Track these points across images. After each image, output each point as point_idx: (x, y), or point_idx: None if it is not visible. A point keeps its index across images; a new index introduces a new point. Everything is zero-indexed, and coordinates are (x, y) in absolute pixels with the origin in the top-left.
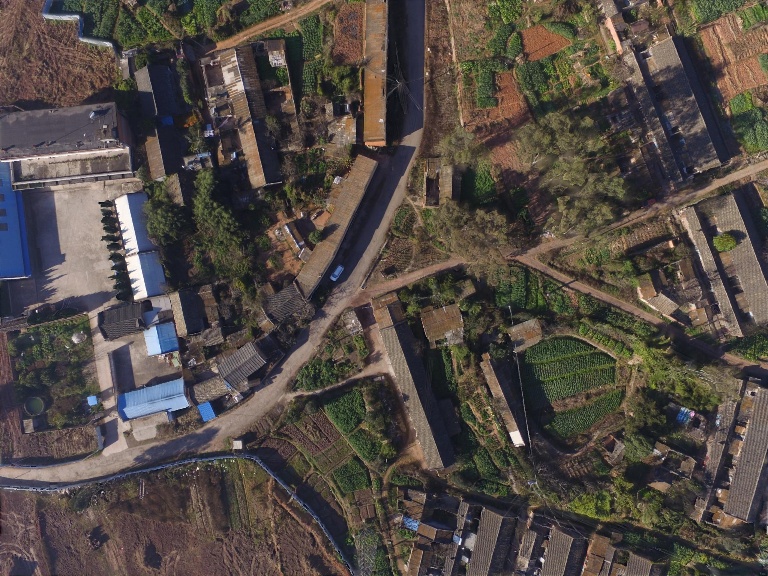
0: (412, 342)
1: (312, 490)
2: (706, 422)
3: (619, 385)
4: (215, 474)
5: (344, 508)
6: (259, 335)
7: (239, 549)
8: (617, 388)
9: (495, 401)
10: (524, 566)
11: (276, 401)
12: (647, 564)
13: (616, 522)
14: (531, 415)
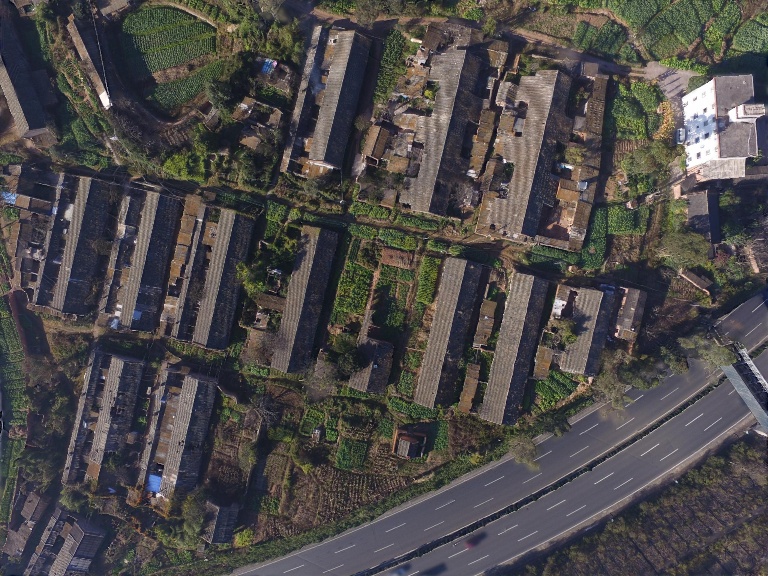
0: None
1: None
2: (291, 73)
3: (222, 55)
4: None
5: None
6: None
7: None
8: (220, 58)
9: (82, 63)
10: (122, 233)
11: None
12: (232, 215)
13: (215, 186)
14: (134, 88)
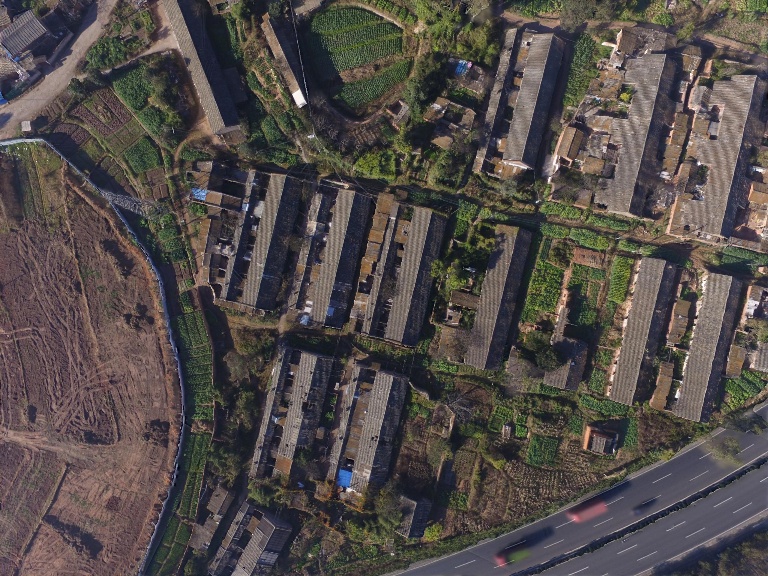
0: (192, 5)
1: (105, 174)
2: (485, 74)
3: (407, 56)
4: (7, 162)
5: (138, 191)
6: (44, 12)
7: (34, 239)
8: (405, 59)
9: (276, 61)
10: (312, 230)
11: (66, 84)
12: (428, 213)
13: (404, 185)
14: (320, 87)
